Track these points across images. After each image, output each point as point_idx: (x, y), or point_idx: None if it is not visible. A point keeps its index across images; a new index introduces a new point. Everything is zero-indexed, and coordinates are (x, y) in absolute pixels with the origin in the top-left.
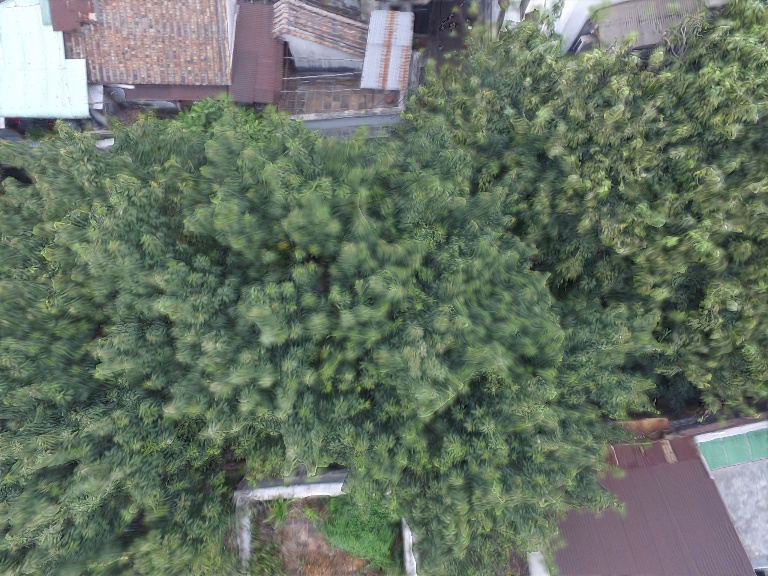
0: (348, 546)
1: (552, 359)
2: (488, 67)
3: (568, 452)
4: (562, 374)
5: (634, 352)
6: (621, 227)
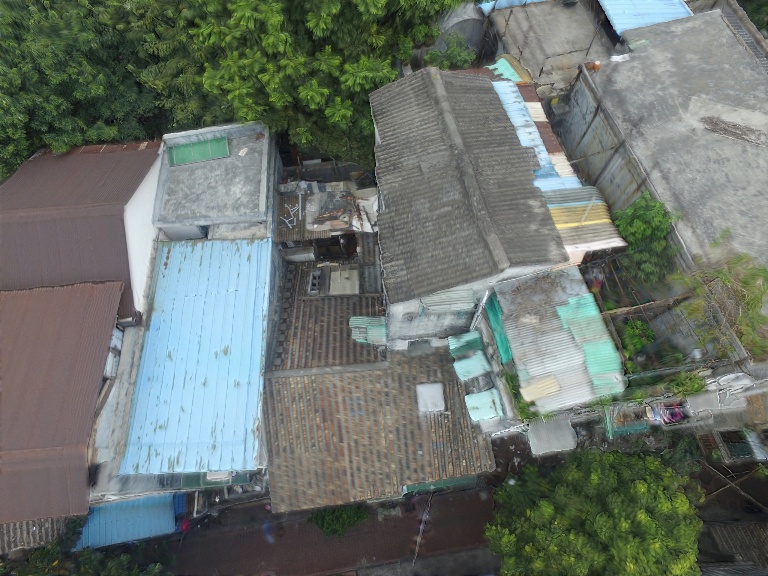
0: None
1: (1, 34)
2: None
3: None
4: None
5: (80, 47)
6: None
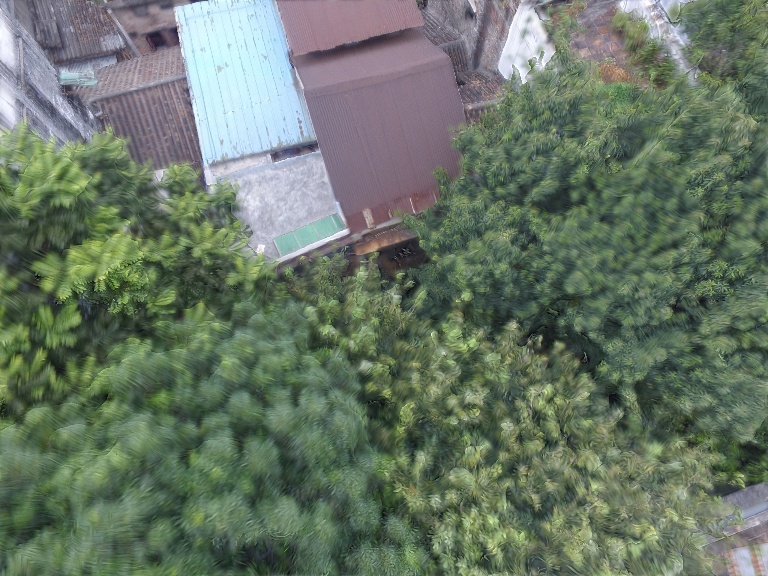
0: (624, 82)
1: None
2: (691, 561)
3: (512, 152)
4: (526, 214)
5: None
6: (511, 359)
